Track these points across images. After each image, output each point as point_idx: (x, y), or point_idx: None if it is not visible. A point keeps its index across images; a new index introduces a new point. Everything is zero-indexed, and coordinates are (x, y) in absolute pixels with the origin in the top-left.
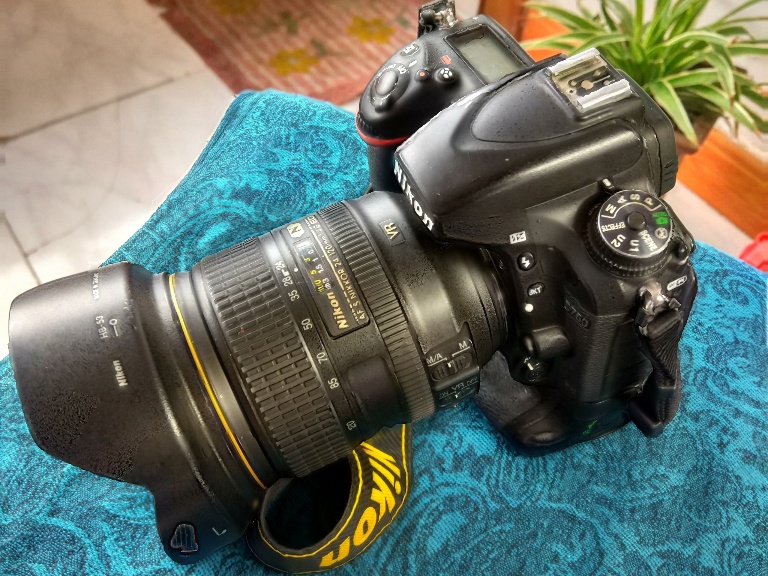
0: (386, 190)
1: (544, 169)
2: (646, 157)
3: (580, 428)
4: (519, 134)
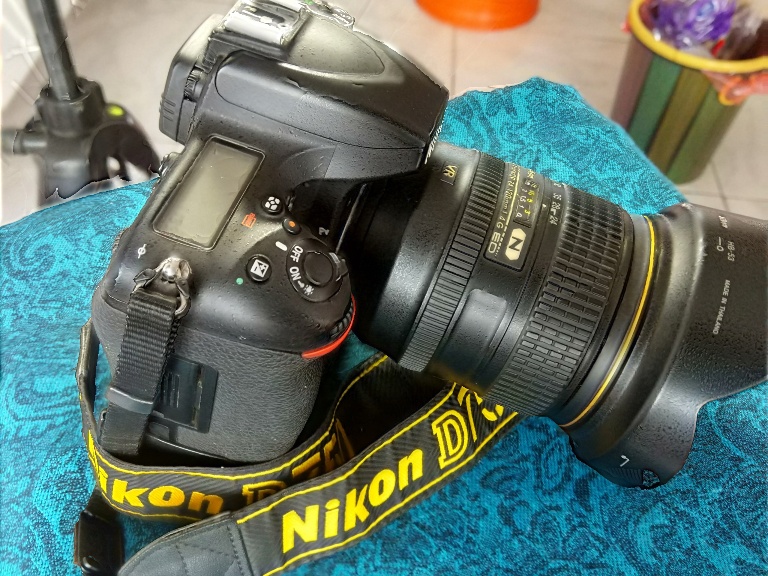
0: None
1: None
2: None
3: None
4: (357, 41)
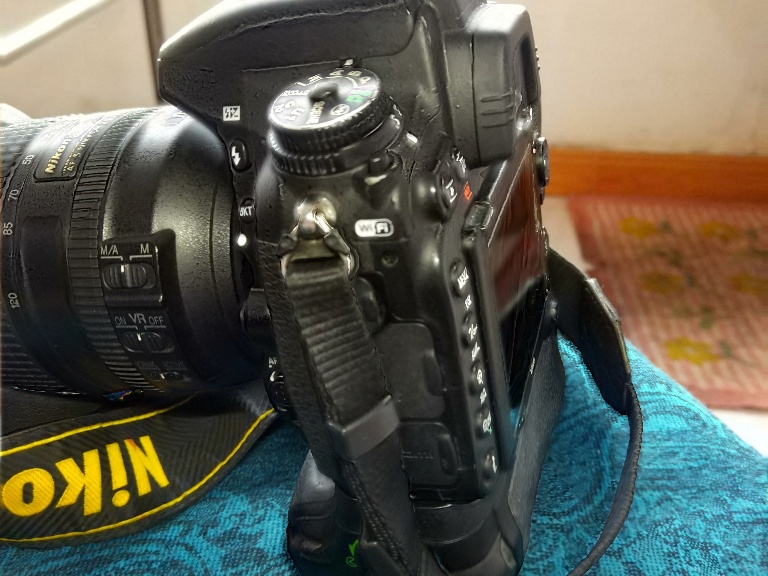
0: None
1: (277, 21)
2: (420, 47)
3: (344, 547)
4: None
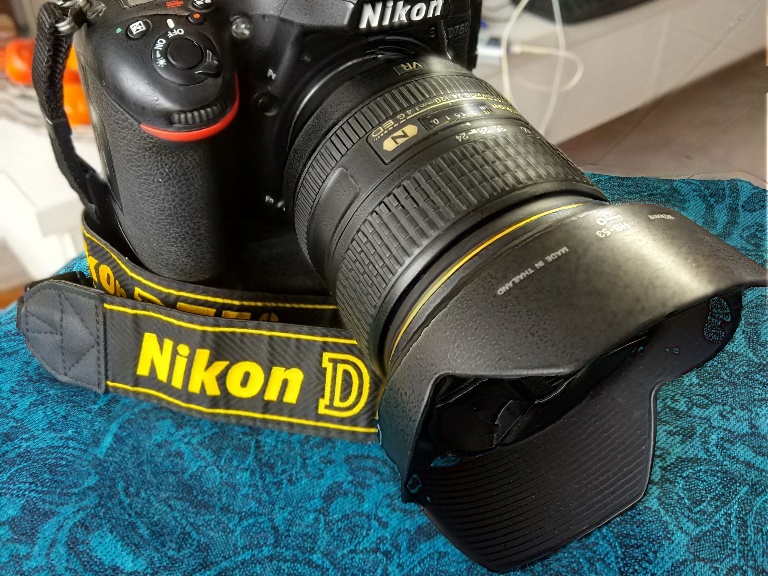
0: (216, 207)
1: None
2: None
3: None
4: None
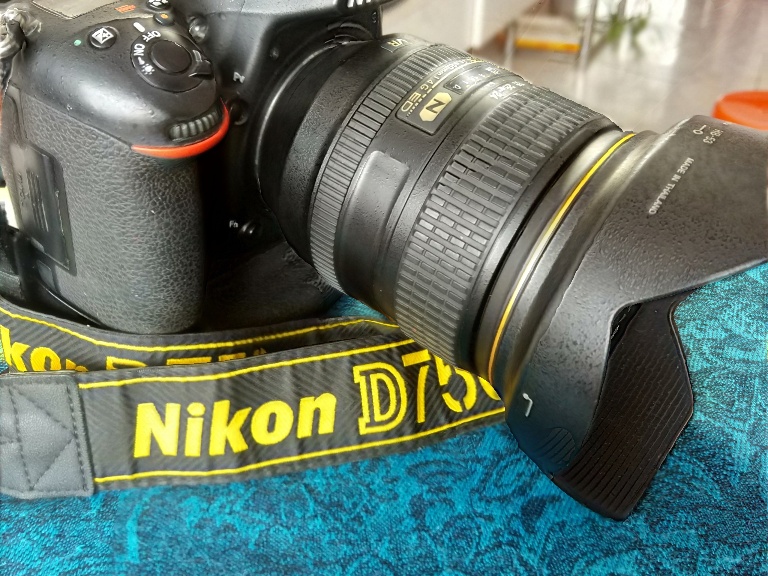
0: (203, 236)
1: None
2: None
3: None
4: None
